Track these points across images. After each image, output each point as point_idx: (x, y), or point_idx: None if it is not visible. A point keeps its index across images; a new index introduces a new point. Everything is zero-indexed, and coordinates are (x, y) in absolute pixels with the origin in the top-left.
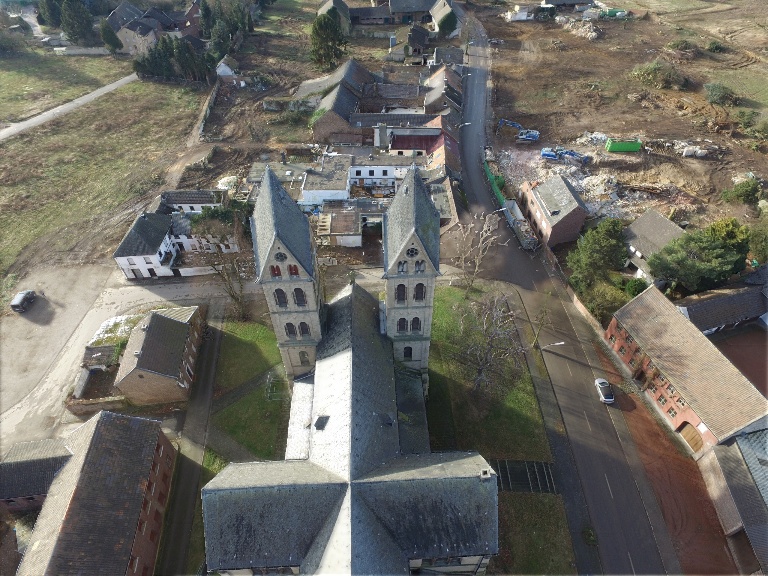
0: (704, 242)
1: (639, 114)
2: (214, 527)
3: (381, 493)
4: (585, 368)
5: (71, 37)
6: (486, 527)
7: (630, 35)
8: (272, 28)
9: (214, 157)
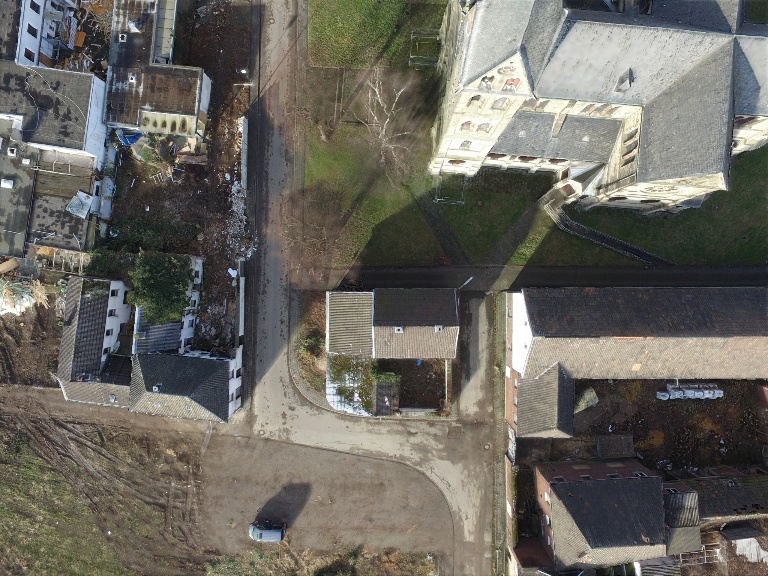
0: None
1: None
2: None
3: None
4: None
5: None
6: None
7: None
8: None
9: None
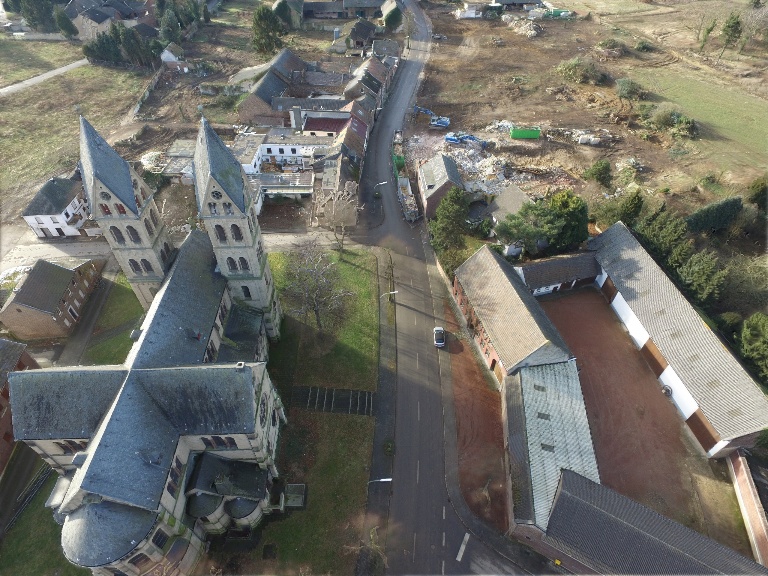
0: (538, 210)
1: (551, 106)
2: (19, 404)
3: (156, 380)
4: (429, 319)
5: (31, 23)
6: (243, 410)
7: (568, 34)
8: (229, 19)
9: (143, 135)
